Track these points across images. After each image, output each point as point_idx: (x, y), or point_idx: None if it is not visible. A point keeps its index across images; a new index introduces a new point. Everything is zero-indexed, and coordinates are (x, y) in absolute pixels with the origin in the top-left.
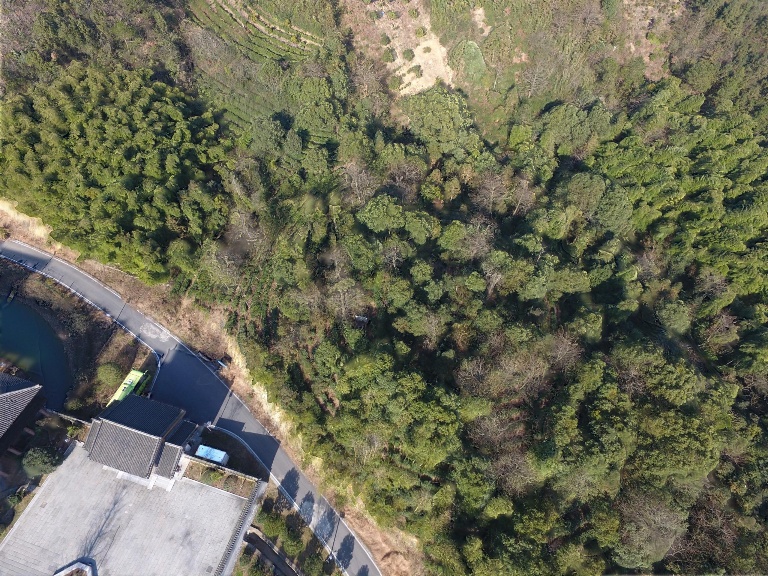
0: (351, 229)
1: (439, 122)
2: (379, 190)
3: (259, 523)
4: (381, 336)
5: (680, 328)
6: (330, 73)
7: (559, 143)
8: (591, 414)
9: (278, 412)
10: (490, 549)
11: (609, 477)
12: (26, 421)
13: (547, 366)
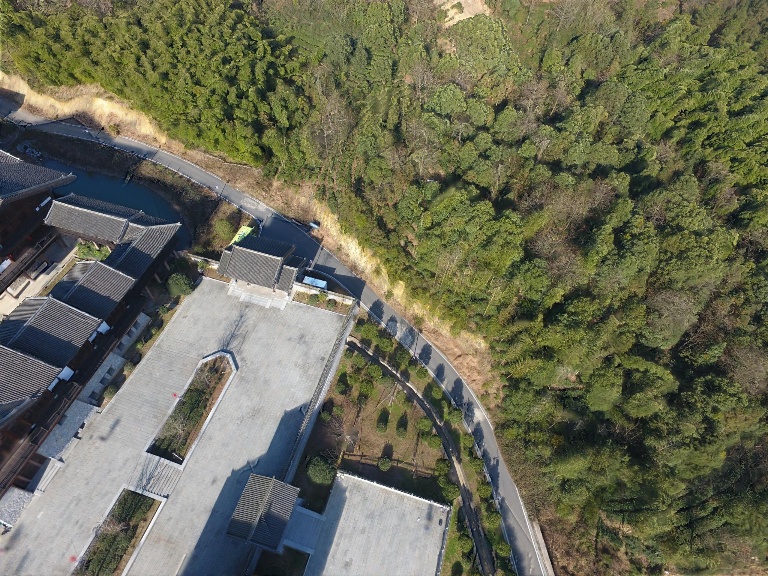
0: None
1: (485, 41)
2: None
3: (356, 334)
4: None
5: (691, 197)
6: (389, 1)
7: (585, 68)
8: (623, 237)
9: (364, 257)
10: None
11: (638, 277)
12: (168, 253)
13: (587, 209)
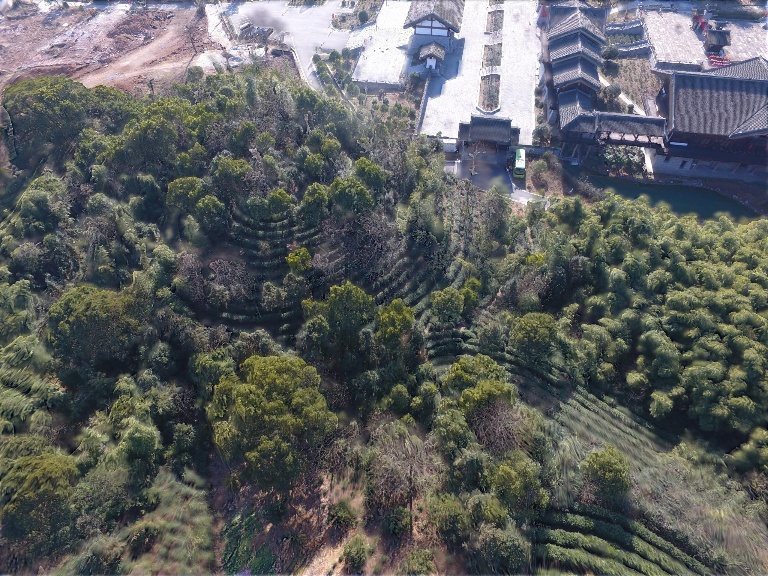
0: None
1: None
2: None
3: None
4: None
5: None
6: None
7: None
8: None
9: None
10: None
11: None
12: None
13: None
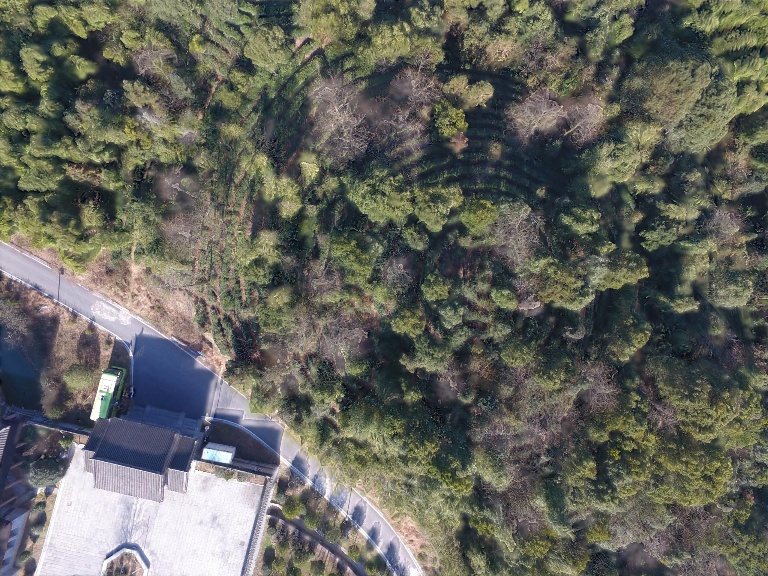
0: (336, 192)
1: None
2: (370, 94)
3: None
4: (385, 355)
5: None
6: None
7: None
8: (611, 452)
9: None
10: (491, 554)
11: None
12: (11, 450)
13: None
